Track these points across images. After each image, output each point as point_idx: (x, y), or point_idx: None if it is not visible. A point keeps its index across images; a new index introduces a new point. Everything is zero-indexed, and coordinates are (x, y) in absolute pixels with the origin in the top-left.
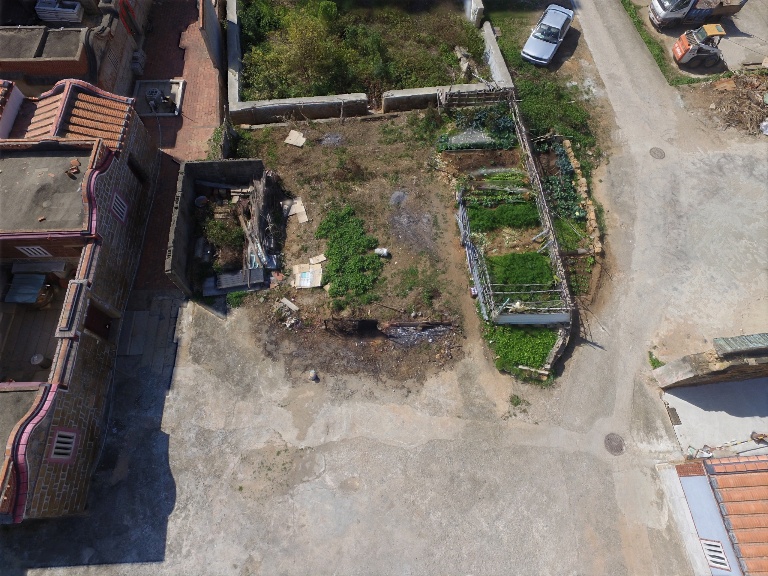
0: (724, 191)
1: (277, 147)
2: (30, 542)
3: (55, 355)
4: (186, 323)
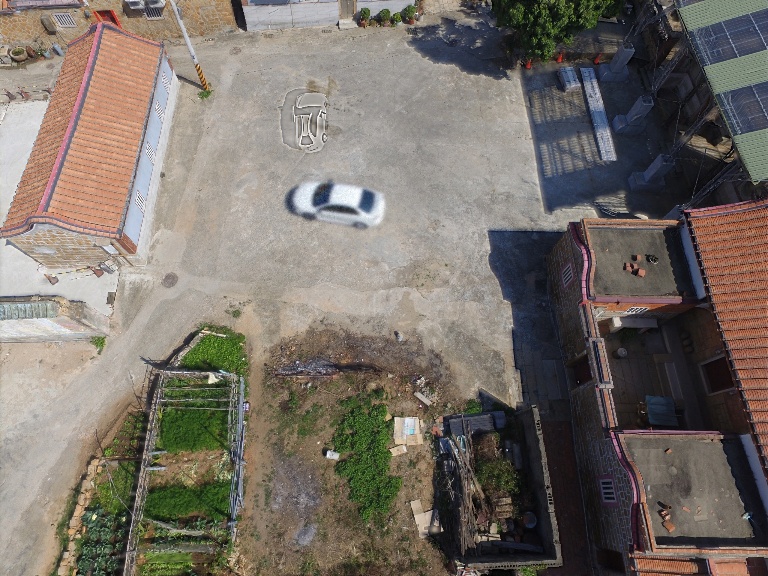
0: None
1: None
2: None
3: None
4: (513, 387)
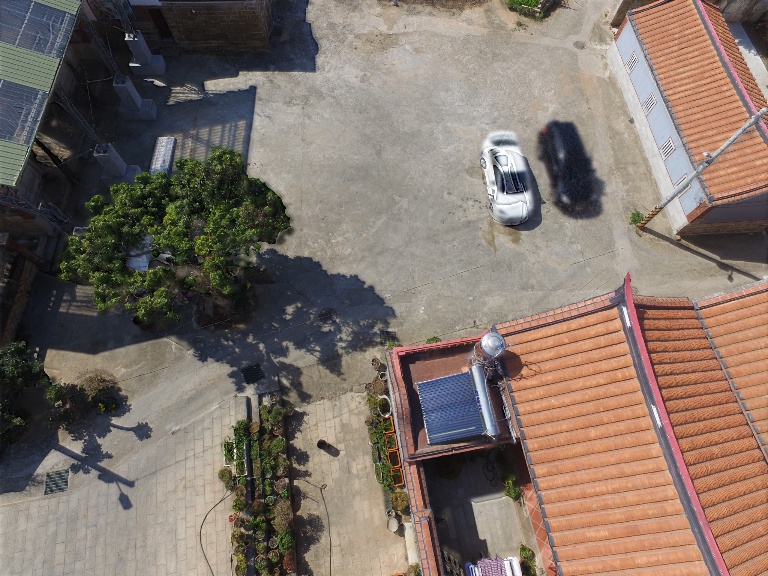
0: None
1: None
2: (238, 62)
3: None
4: None
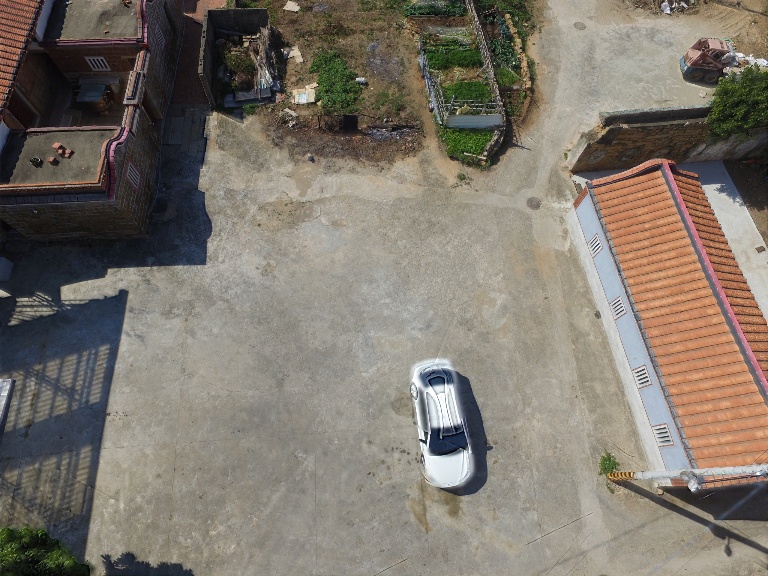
0: (630, 51)
1: (277, 12)
2: (108, 254)
3: (124, 117)
4: (213, 125)
